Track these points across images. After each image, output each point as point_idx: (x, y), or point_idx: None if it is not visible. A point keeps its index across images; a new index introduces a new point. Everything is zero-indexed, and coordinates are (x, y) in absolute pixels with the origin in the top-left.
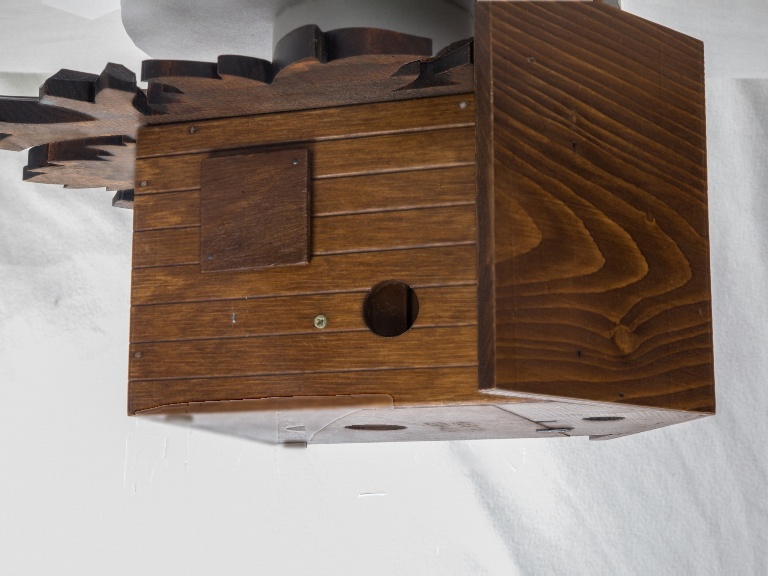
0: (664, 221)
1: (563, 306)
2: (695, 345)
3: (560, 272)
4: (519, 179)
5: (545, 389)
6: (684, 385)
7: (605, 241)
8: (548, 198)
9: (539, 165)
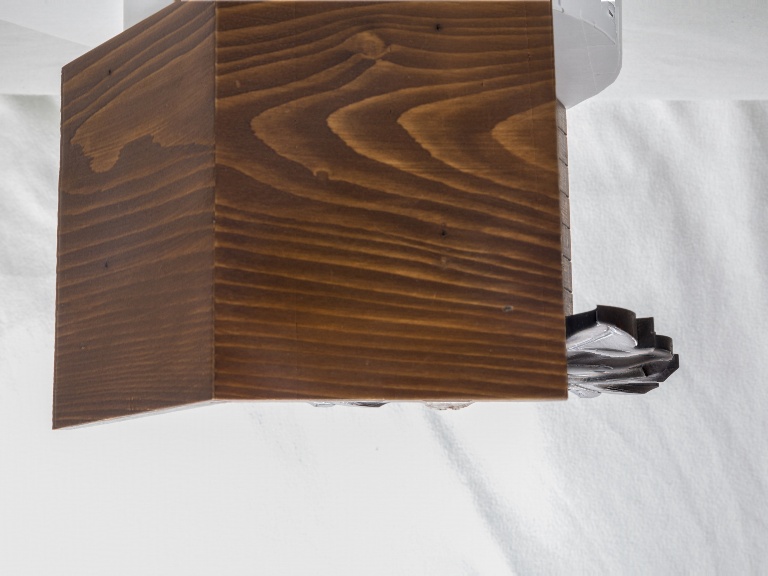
0: (298, 175)
1: (461, 70)
2: (250, 48)
3: (465, 102)
4: (524, 185)
5: None
6: (271, 6)
7: (397, 141)
8: (483, 172)
9: (496, 203)
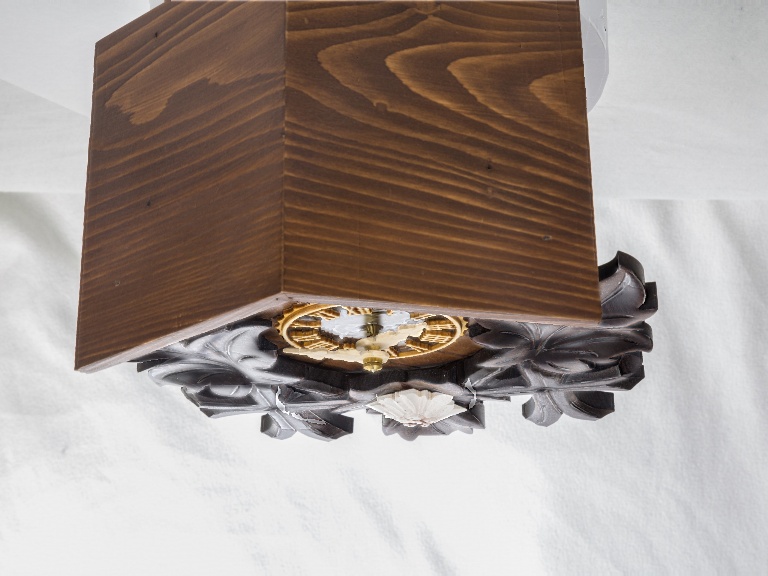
0: (359, 104)
1: (502, 32)
2: None
3: (506, 59)
4: (558, 134)
5: None
6: None
7: (447, 85)
8: (522, 120)
9: (534, 147)
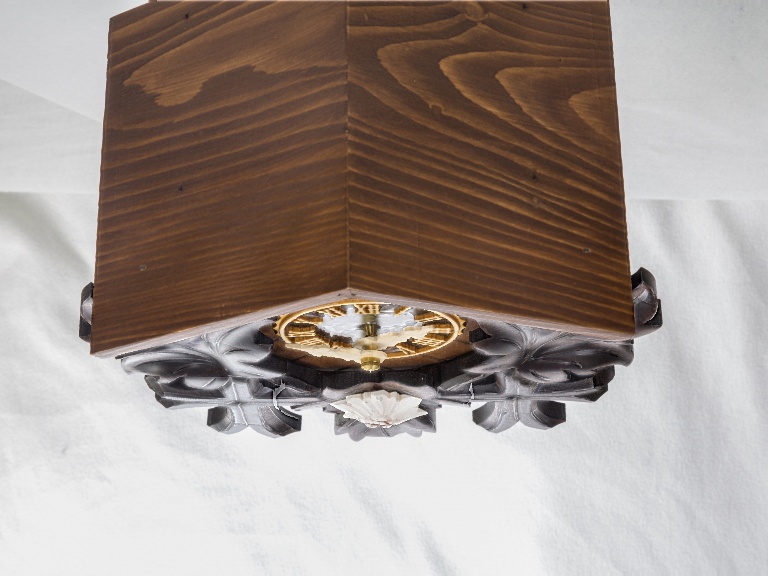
0: (416, 105)
1: (543, 45)
2: None
3: (548, 72)
4: (595, 149)
5: None
6: None
7: (495, 93)
8: (563, 133)
9: (574, 160)
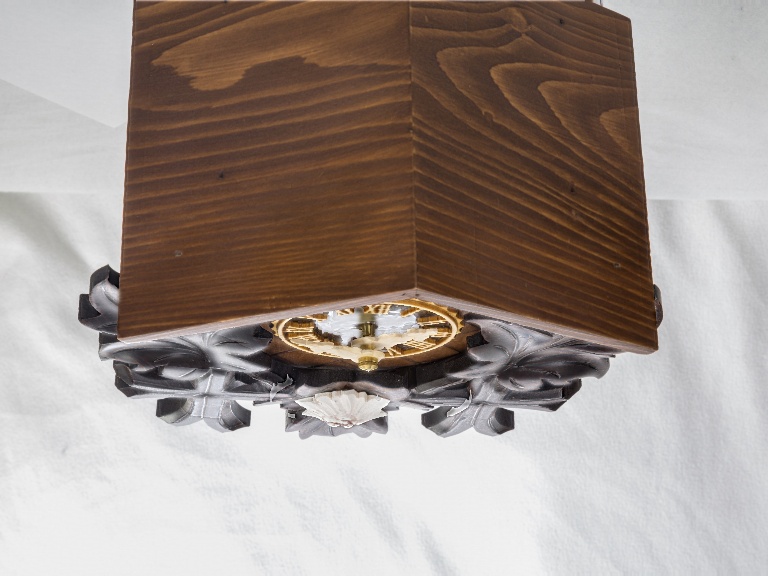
0: (471, 110)
1: (578, 62)
2: None
3: (582, 88)
4: (622, 167)
5: (591, 6)
6: None
7: (538, 104)
8: (596, 149)
9: (605, 176)
